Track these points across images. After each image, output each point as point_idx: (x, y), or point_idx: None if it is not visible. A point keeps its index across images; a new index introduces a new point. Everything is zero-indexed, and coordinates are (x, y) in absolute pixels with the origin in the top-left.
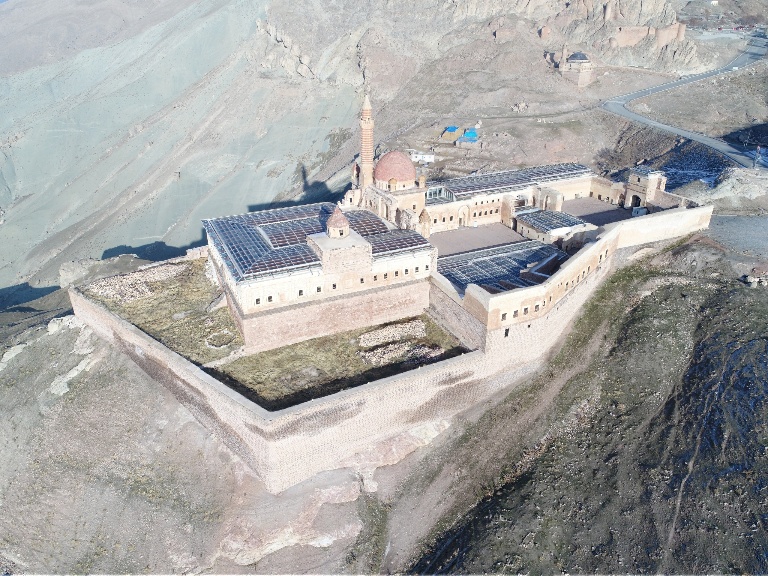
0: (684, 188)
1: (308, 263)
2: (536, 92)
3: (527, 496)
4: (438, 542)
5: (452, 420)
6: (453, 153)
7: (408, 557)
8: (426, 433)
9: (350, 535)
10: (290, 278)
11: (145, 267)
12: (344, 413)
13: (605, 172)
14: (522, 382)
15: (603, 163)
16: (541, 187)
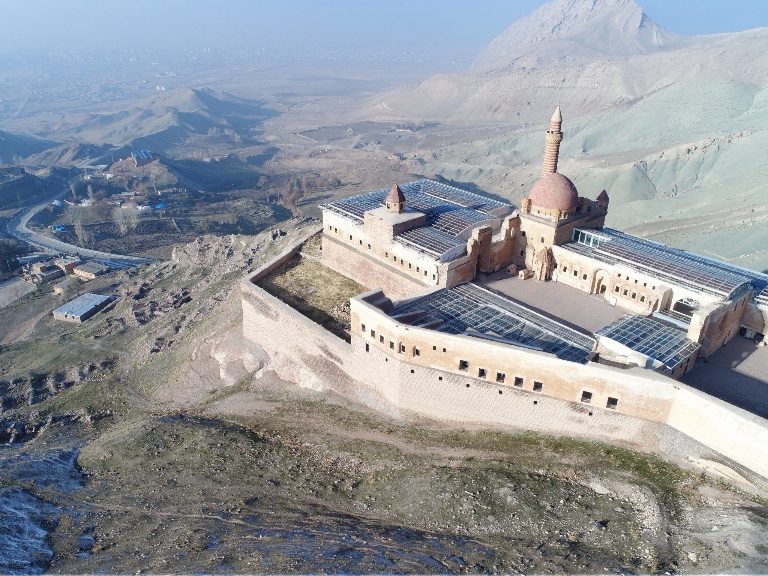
0: None
1: (359, 217)
2: None
3: (234, 439)
4: (216, 420)
5: (325, 390)
6: None
7: (211, 413)
8: (307, 380)
9: (227, 383)
10: (346, 221)
11: None
12: None
13: None
14: (378, 415)
15: None
16: None
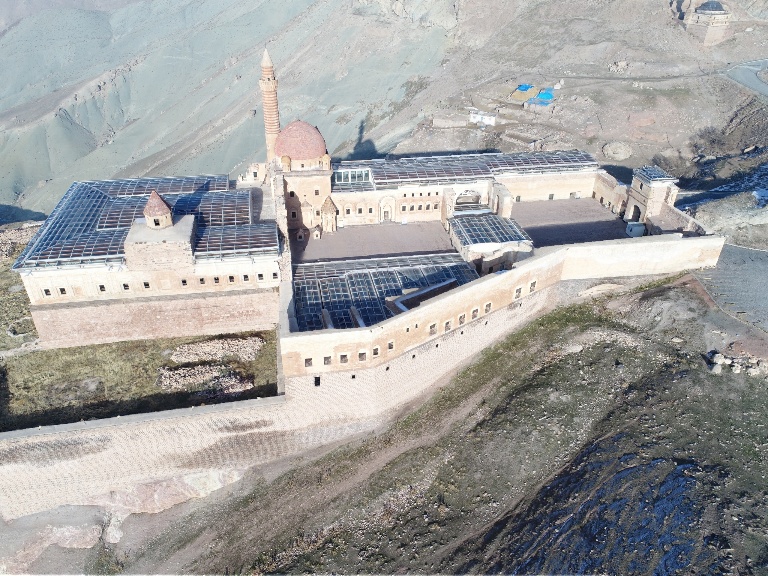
0: (720, 202)
1: (109, 255)
2: (645, 49)
3: None
4: None
5: (245, 472)
6: (519, 116)
7: None
8: (205, 483)
9: None
10: (84, 270)
11: (28, 225)
12: (82, 447)
13: (699, 157)
14: (349, 442)
15: (701, 145)
16: (518, 180)
